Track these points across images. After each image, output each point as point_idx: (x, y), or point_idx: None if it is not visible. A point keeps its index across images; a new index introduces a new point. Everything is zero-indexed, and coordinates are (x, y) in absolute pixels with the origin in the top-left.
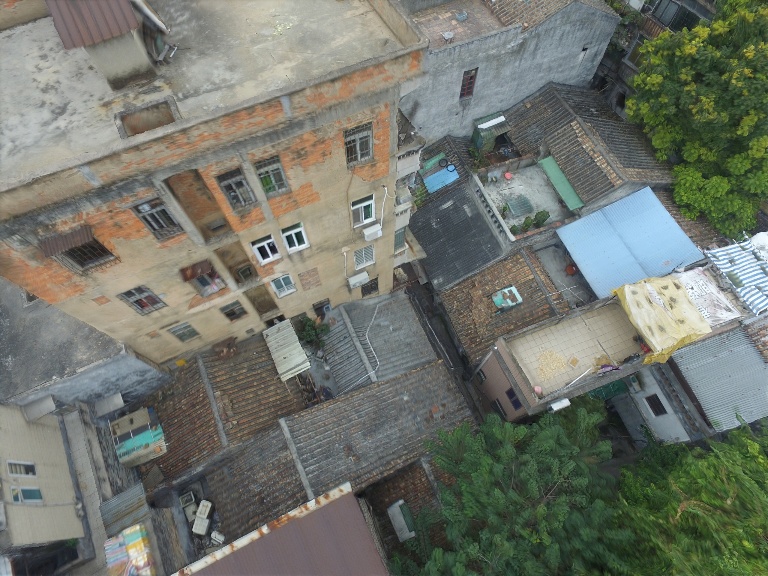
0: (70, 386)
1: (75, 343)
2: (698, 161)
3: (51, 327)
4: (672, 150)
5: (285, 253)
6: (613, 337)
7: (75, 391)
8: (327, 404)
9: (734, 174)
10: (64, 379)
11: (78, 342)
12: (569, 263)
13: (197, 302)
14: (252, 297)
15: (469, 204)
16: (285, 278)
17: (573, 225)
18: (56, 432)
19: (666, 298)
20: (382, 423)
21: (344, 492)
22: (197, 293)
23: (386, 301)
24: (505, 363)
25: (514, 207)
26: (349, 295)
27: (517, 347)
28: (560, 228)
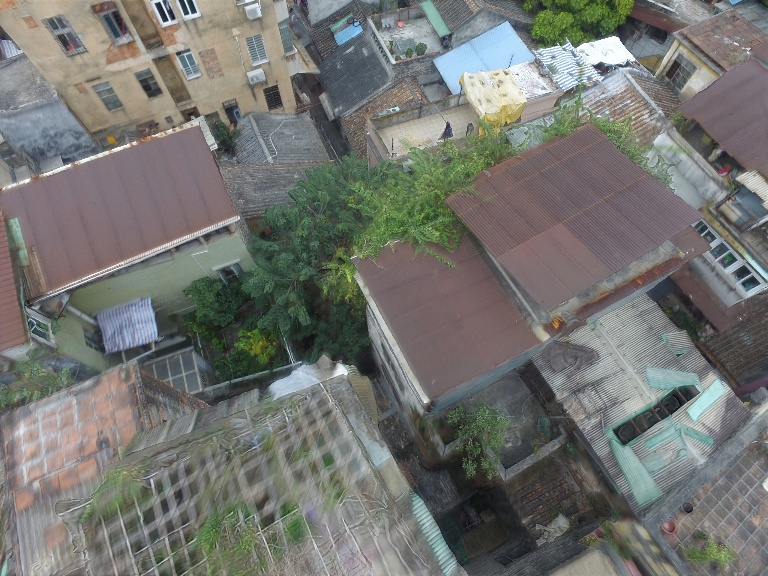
0: (15, 126)
1: (19, 91)
2: (555, 7)
3: (1, 82)
4: (536, 1)
5: (181, 18)
6: (464, 126)
7: (20, 136)
8: (226, 167)
9: (577, 9)
10: (9, 111)
11: (21, 91)
12: (447, 92)
13: (113, 57)
14: (169, 88)
15: (367, 47)
16: (189, 56)
17: (447, 55)
18: (6, 172)
19: (495, 80)
20: (272, 186)
21: (194, 126)
22: (110, 41)
23: (292, 120)
24: (373, 143)
25: (402, 46)
26: (255, 102)
27: (385, 133)
28: (436, 58)
